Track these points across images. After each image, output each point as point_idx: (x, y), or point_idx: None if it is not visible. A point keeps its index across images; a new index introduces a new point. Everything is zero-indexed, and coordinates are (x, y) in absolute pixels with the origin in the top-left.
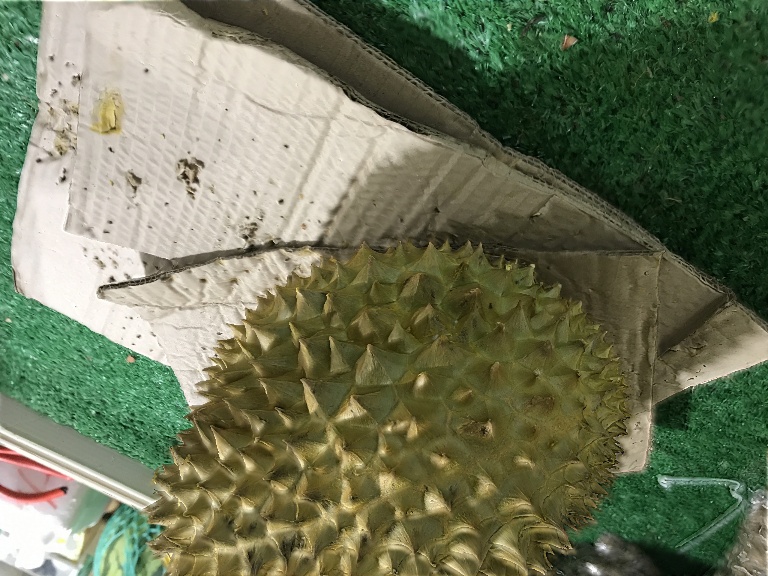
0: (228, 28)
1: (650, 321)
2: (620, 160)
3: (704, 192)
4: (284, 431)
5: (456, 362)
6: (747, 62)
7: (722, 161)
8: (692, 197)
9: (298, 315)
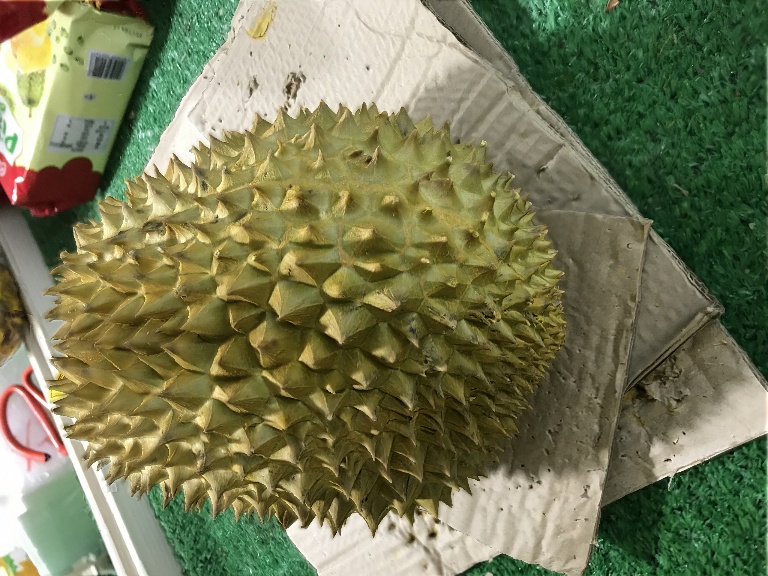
0: None
1: (625, 322)
2: (636, 134)
3: (711, 182)
4: None
5: (384, 133)
6: (764, 32)
7: (732, 144)
8: (699, 188)
9: None
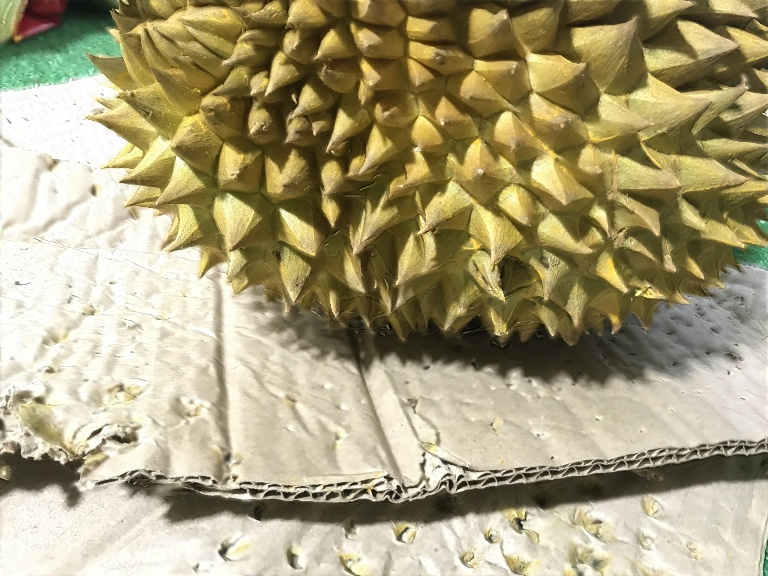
0: None
1: None
2: None
3: None
4: None
5: None
6: None
7: None
8: None
9: None
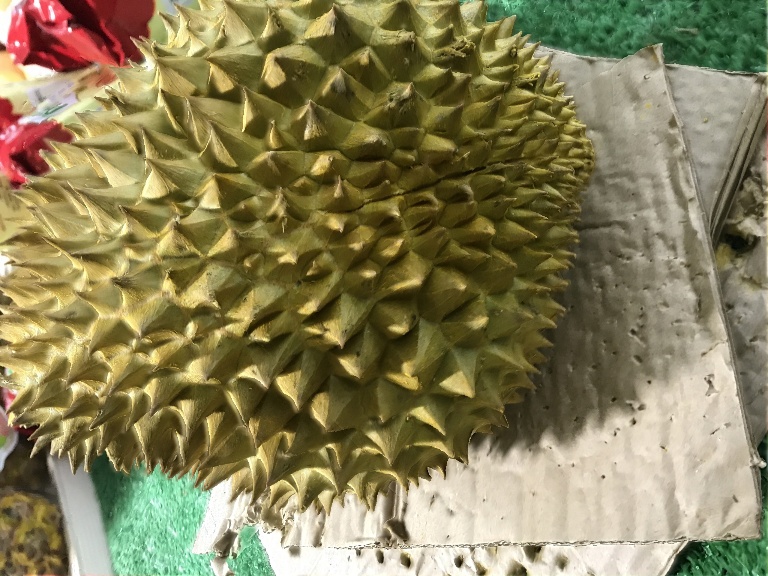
0: None
1: (675, 154)
2: (623, 19)
3: (715, 4)
4: None
5: None
6: None
7: None
8: (706, 18)
9: None
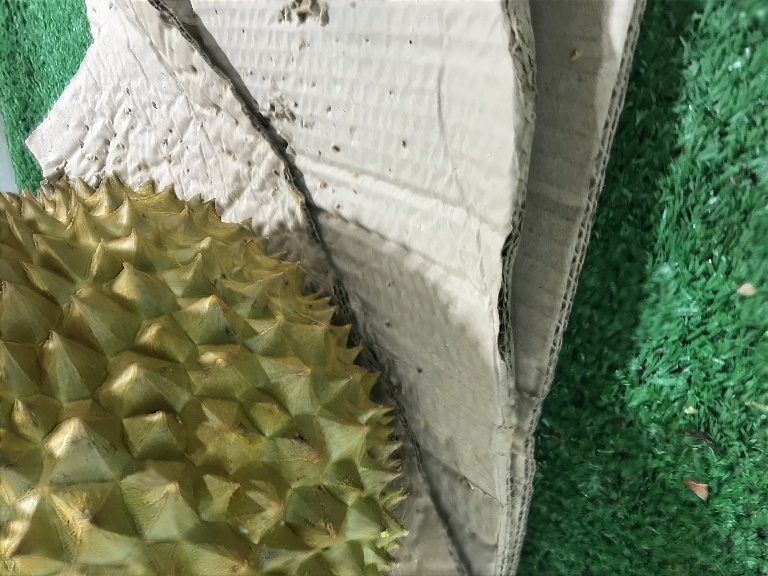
0: (525, 22)
1: None
2: (576, 557)
3: None
4: (3, 410)
5: None
6: None
7: None
8: None
9: (181, 312)
